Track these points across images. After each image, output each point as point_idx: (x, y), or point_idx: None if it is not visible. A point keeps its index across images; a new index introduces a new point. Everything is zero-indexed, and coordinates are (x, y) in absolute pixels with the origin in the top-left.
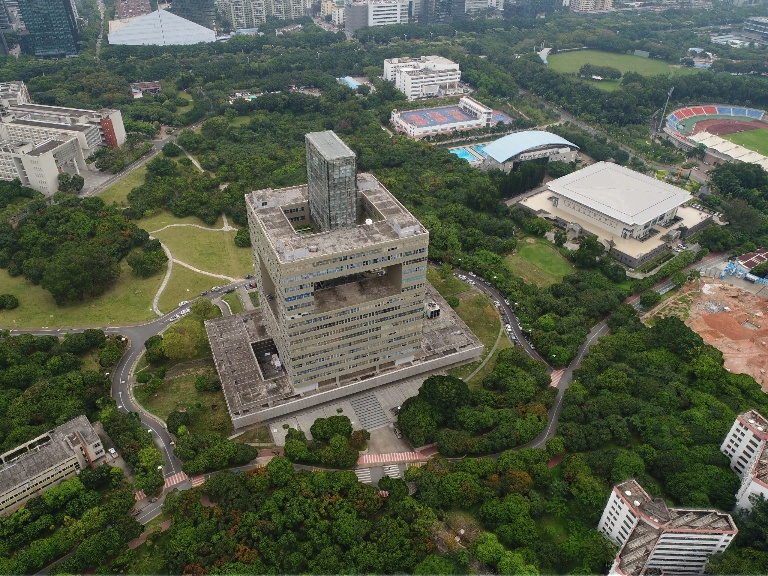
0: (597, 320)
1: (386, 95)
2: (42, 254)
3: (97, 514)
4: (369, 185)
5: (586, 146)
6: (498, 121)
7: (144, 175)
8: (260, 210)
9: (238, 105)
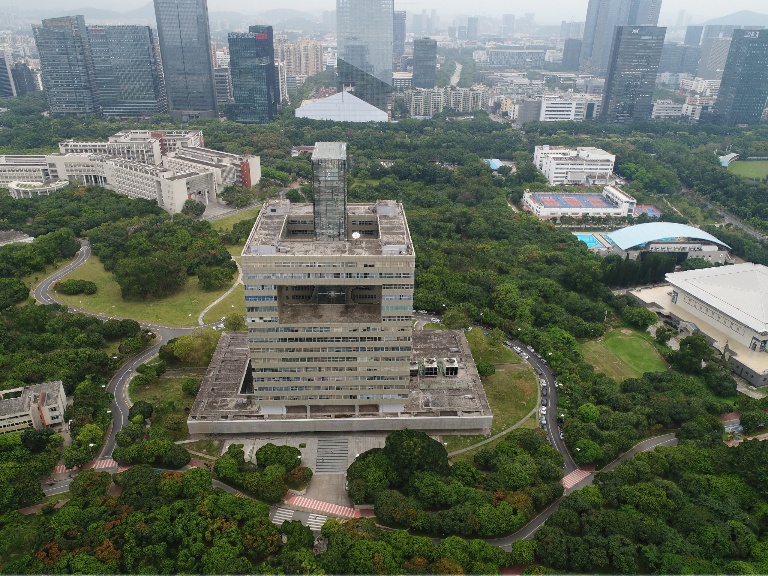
0: (669, 429)
1: (525, 177)
2: (137, 257)
3: (10, 468)
4: (389, 210)
5: (745, 250)
6: (642, 213)
7: None
8: (267, 216)
9: (373, 169)
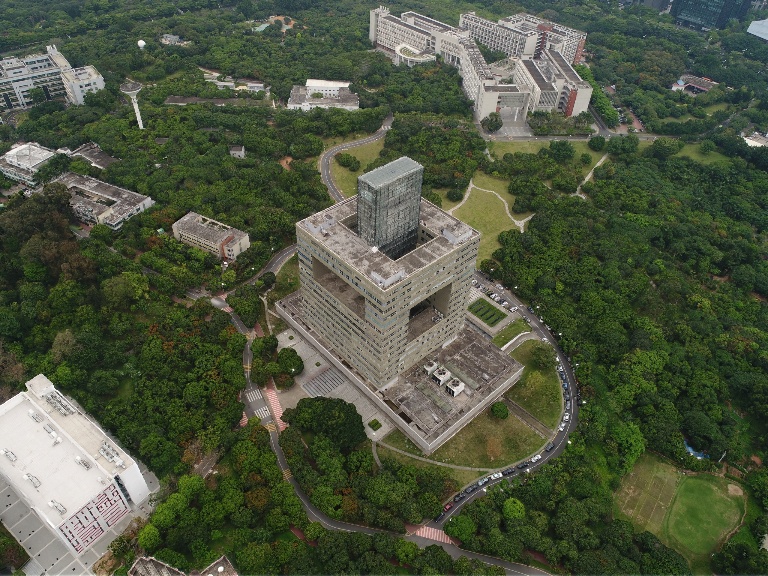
0: None
1: None
2: (406, 153)
3: (183, 272)
4: (451, 236)
5: None
6: None
7: (548, 149)
8: None
9: (729, 142)
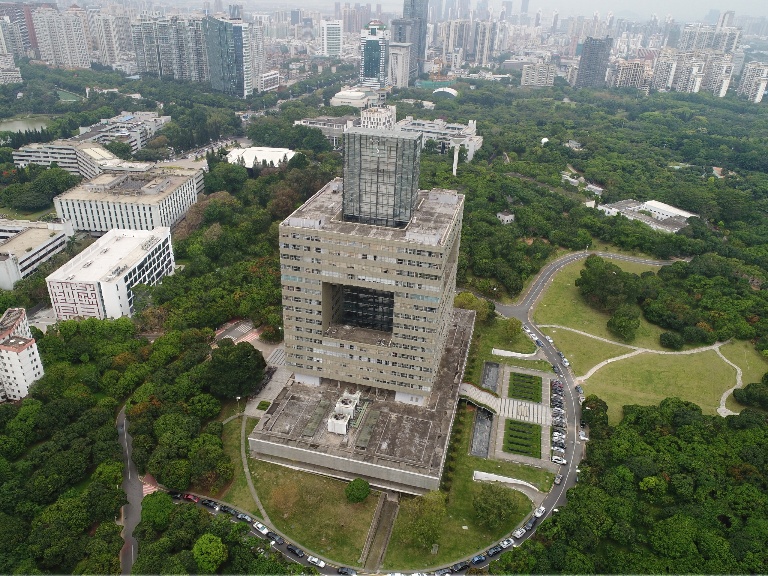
0: None
1: None
2: (670, 285)
3: None
4: None
5: None
6: None
7: None
8: None
9: None
